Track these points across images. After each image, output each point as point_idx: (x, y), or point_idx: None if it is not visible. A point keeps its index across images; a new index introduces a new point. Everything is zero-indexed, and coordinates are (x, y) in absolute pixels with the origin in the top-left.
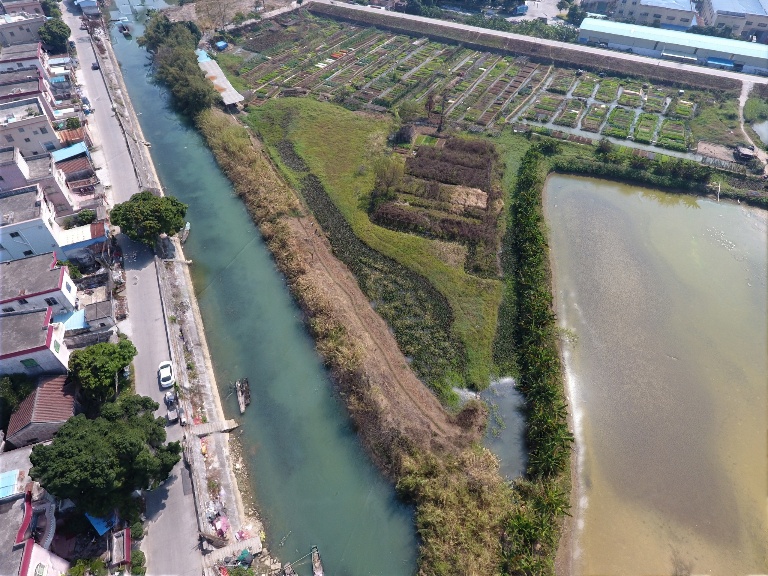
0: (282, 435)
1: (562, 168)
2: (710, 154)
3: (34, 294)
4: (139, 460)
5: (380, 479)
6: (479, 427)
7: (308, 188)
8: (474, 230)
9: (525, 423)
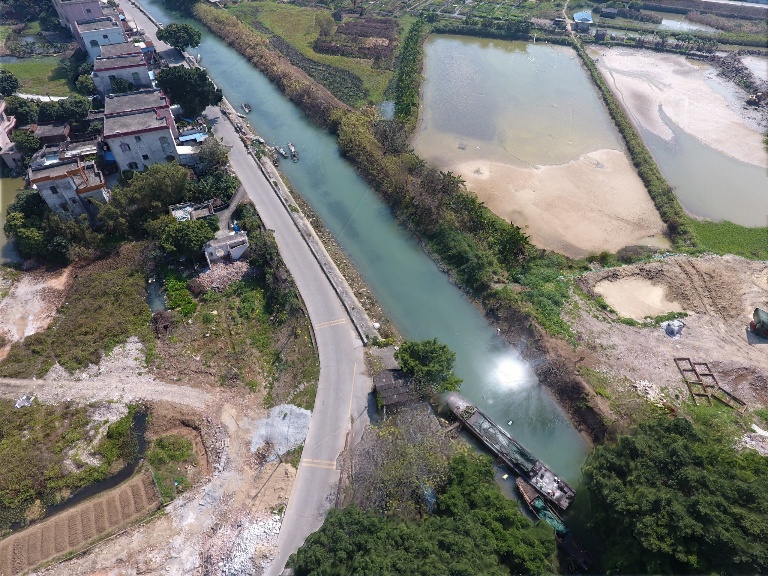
0: (269, 119)
1: (440, 30)
2: None
3: (128, 54)
4: (207, 82)
5: (321, 128)
6: None
7: (274, 41)
8: (378, 51)
9: (395, 108)
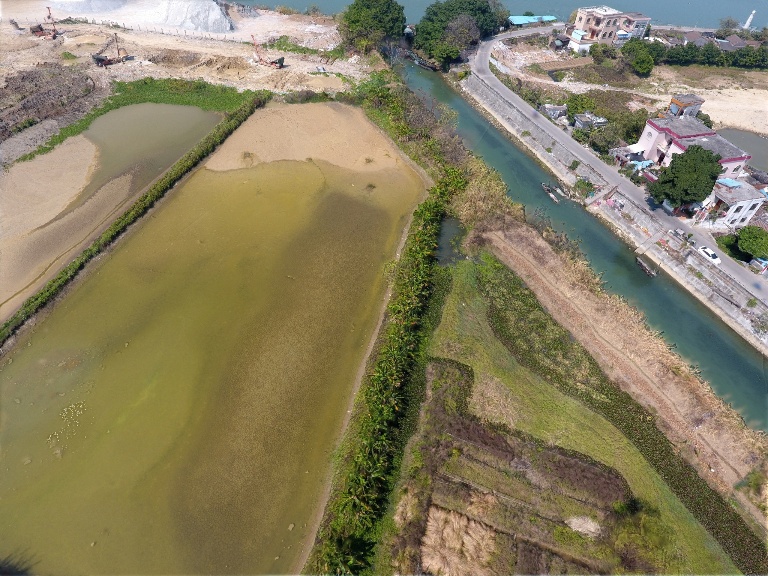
0: (602, 246)
1: None
2: None
3: None
4: None
5: None
6: (469, 237)
7: None
8: None
9: None
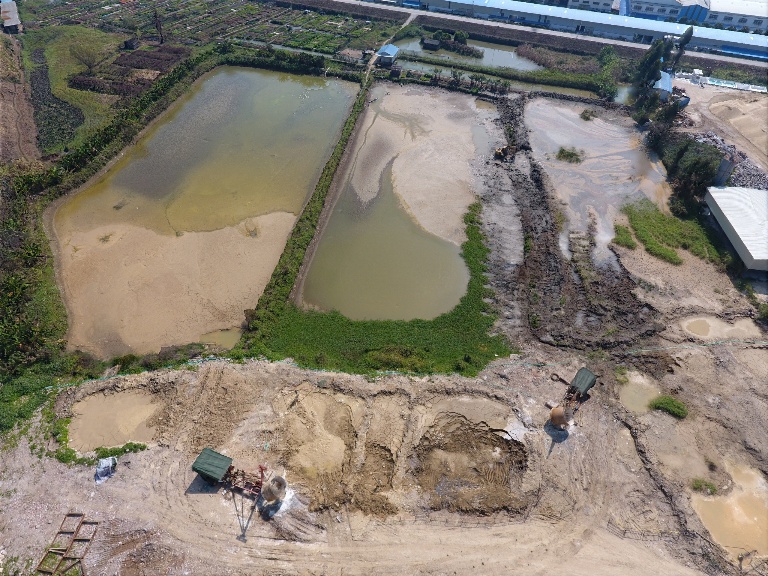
0: None
1: (231, 61)
2: (346, 55)
3: None
4: None
5: None
6: (53, 161)
7: (37, 71)
8: (128, 87)
9: None
